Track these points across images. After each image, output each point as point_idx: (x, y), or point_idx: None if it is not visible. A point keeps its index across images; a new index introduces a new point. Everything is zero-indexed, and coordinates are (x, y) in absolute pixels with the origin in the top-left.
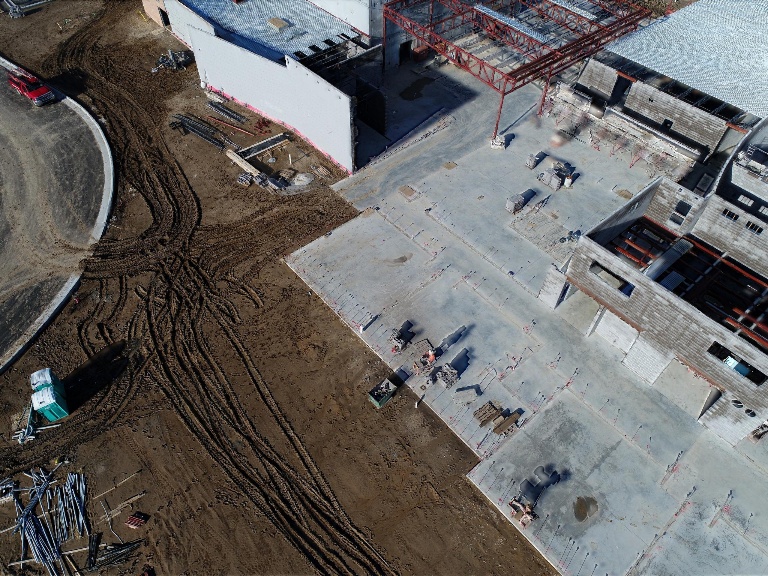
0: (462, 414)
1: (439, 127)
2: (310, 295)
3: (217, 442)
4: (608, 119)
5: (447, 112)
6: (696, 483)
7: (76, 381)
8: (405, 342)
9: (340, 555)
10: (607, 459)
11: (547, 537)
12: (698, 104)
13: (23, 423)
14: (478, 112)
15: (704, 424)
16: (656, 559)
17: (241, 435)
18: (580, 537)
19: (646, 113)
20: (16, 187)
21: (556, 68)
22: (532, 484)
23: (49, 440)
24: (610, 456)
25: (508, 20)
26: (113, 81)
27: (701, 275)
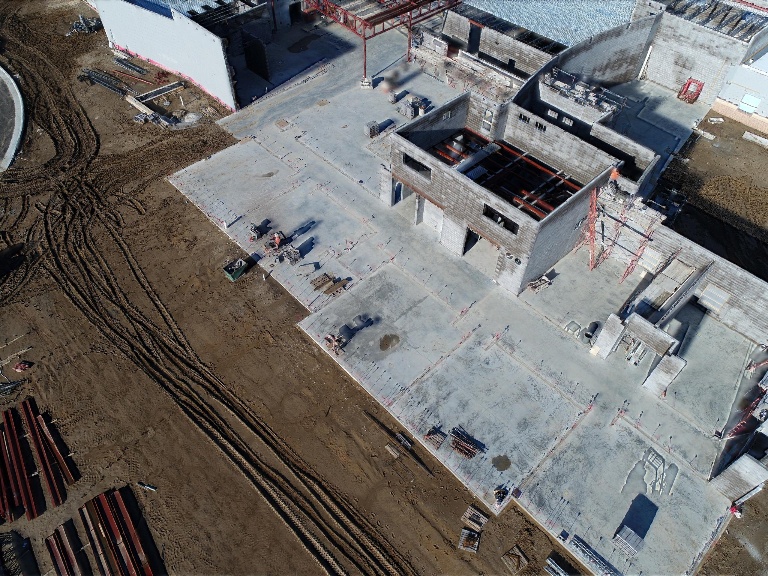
0: (301, 283)
1: (318, 73)
2: (186, 203)
3: (95, 311)
4: (457, 59)
5: (328, 61)
6: (481, 322)
7: None
8: (262, 234)
9: (187, 382)
10: (414, 309)
11: (355, 362)
12: (533, 44)
13: None
14: (355, 61)
15: (497, 282)
16: (438, 372)
17: (116, 305)
18: (381, 361)
19: (495, 55)
20: None
21: (416, 18)
22: (349, 328)
23: None
24: (416, 307)
25: None
26: (29, 44)
27: (502, 168)
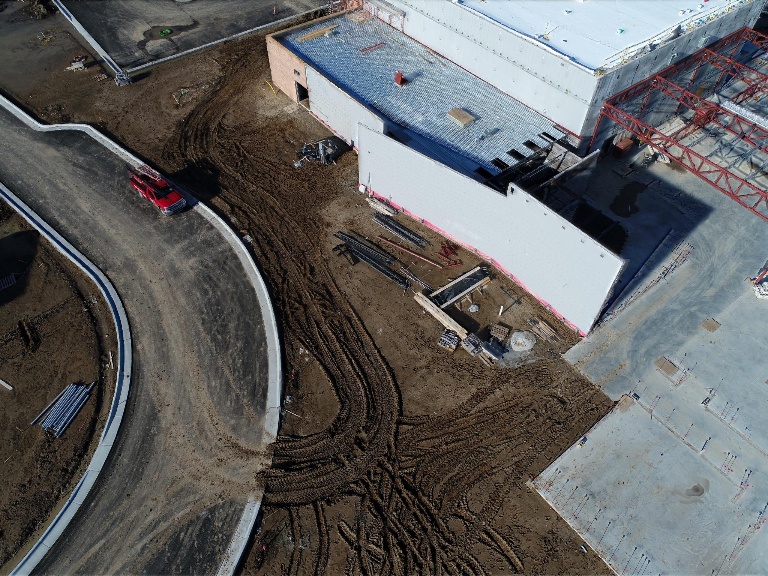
0: None
1: (676, 261)
2: (585, 553)
3: None
4: None
5: (679, 237)
6: None
7: None
8: None
9: None
10: None
11: None
12: None
13: None
14: (719, 238)
15: None
16: None
17: None
18: None
19: None
20: (156, 342)
21: None
22: None
23: None
24: None
25: None
26: (250, 179)
27: None
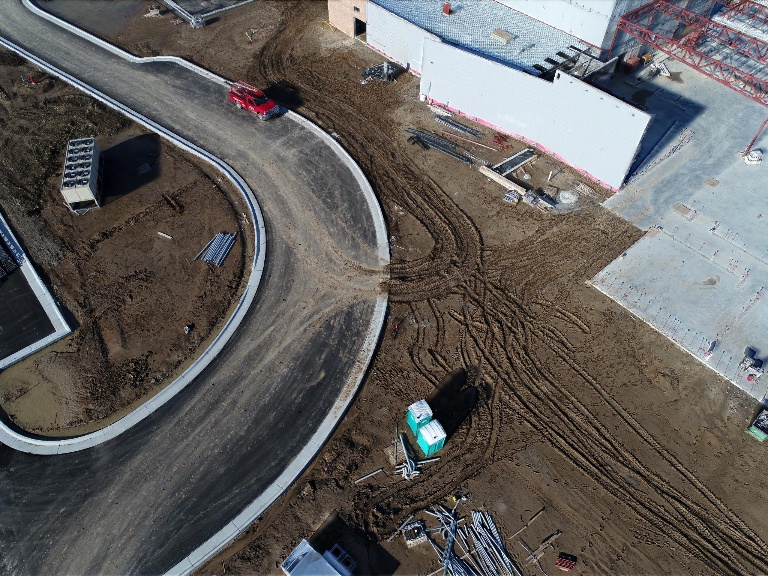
0: None
1: (682, 142)
2: (634, 320)
3: (609, 477)
4: None
5: (682, 126)
6: None
7: (433, 412)
8: None
9: None
10: None
11: None
12: None
13: (400, 457)
14: (714, 126)
15: None
16: None
17: (630, 470)
18: None
19: None
20: (279, 205)
21: None
22: None
23: (434, 475)
24: None
25: (754, 33)
26: (327, 94)
27: None
